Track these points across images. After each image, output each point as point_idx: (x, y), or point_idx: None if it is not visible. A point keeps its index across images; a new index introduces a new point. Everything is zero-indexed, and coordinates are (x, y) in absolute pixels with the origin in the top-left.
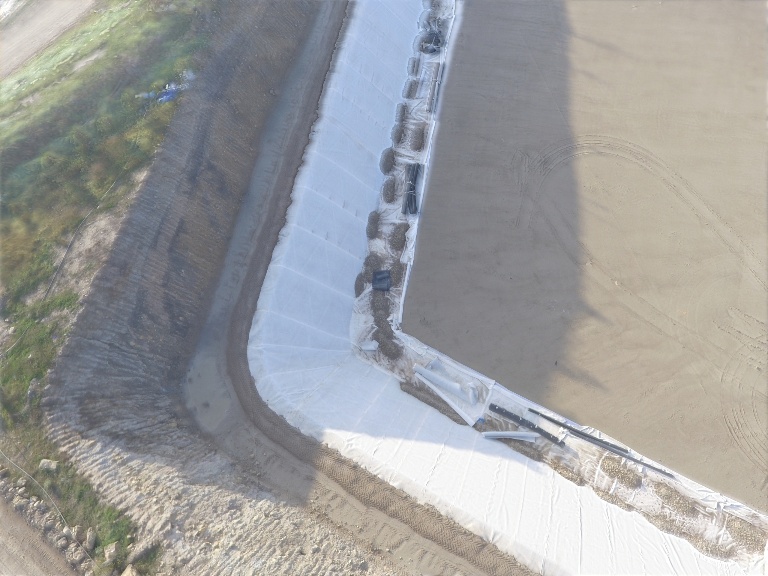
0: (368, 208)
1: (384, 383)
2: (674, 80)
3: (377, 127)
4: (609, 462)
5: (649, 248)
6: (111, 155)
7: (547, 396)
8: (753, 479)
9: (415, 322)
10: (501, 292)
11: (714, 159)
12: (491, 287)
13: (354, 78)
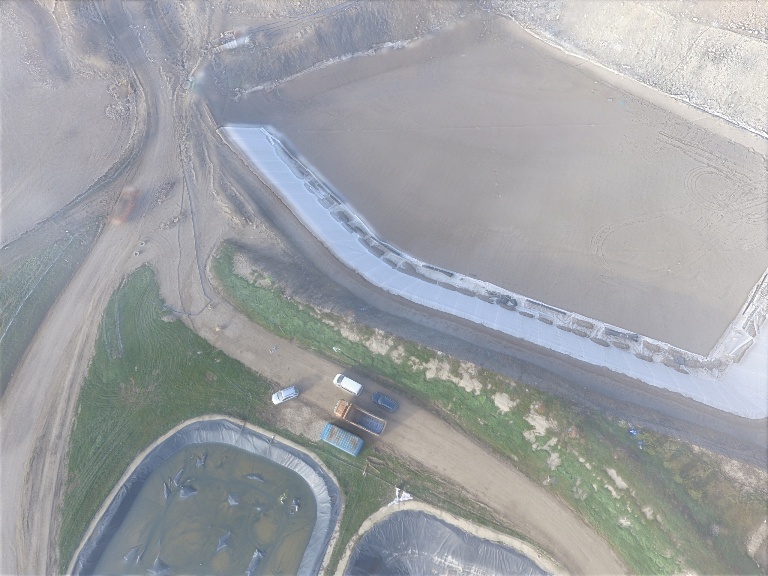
0: None
1: (737, 369)
2: (558, 199)
3: None
4: (763, 293)
5: (660, 245)
6: (685, 462)
7: (736, 306)
8: (764, 250)
9: (702, 350)
10: (685, 309)
11: (611, 203)
12: (682, 313)
13: None
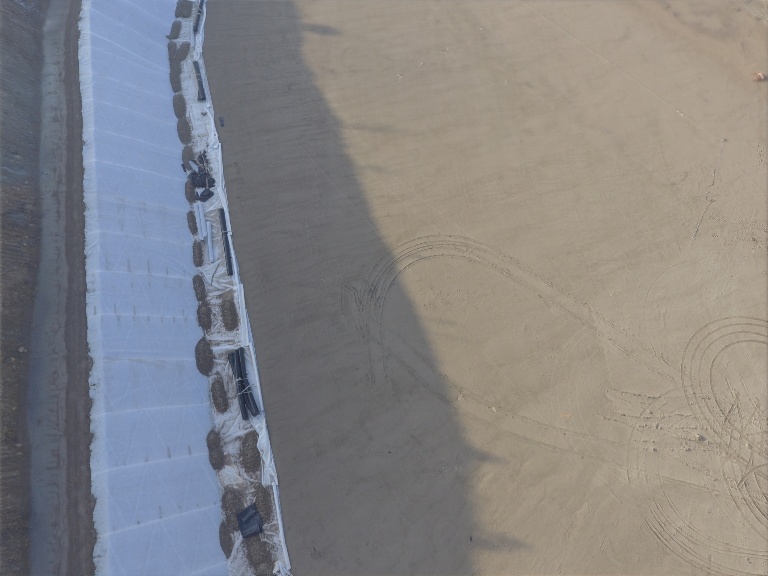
0: (202, 432)
1: None
2: (465, 148)
3: (177, 323)
4: None
5: (510, 353)
6: None
7: None
8: None
9: (306, 560)
10: (385, 475)
11: (532, 225)
12: (373, 473)
13: (124, 283)
